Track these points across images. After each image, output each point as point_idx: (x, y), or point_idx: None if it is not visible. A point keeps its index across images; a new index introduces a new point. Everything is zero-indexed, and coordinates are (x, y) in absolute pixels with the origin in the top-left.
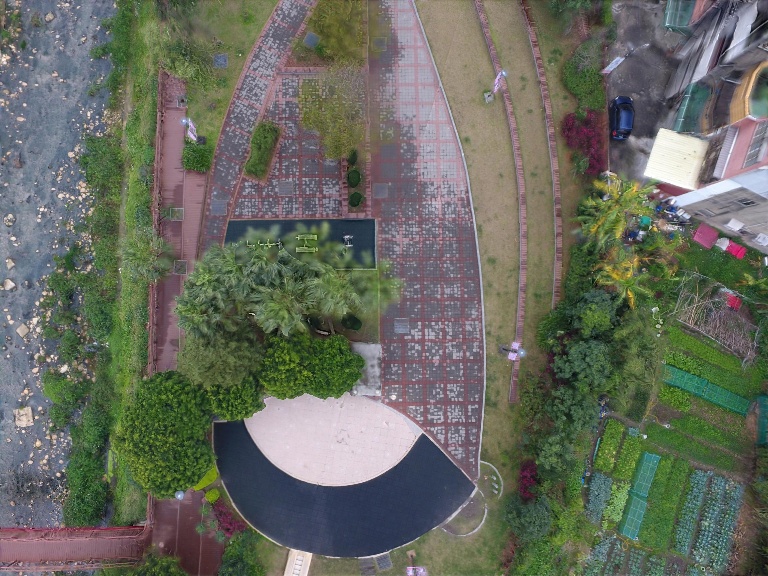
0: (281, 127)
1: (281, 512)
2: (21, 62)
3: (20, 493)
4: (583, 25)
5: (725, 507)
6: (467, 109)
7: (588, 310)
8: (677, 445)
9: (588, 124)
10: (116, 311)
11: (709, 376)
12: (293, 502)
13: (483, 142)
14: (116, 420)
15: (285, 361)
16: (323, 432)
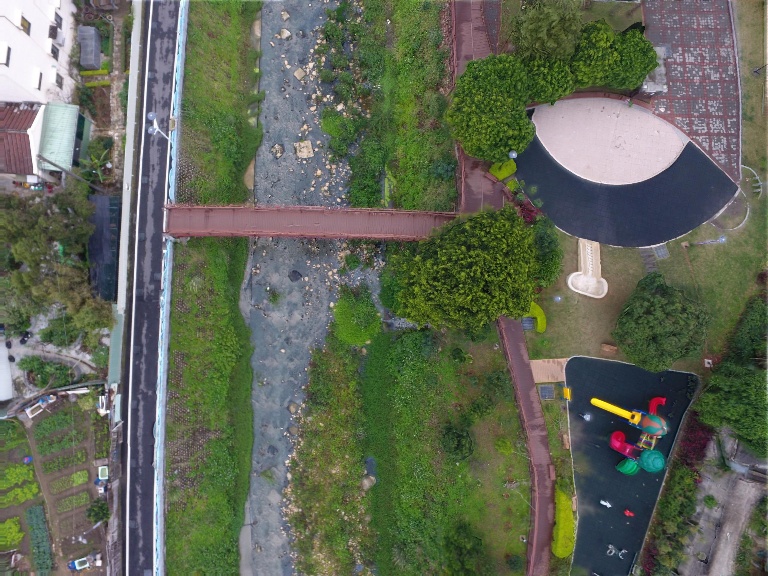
0: None
1: (570, 206)
2: None
3: None
4: None
5: None
6: None
7: None
8: None
9: None
10: (388, 54)
11: None
12: (580, 197)
13: None
14: (396, 146)
15: (603, 39)
16: (603, 138)
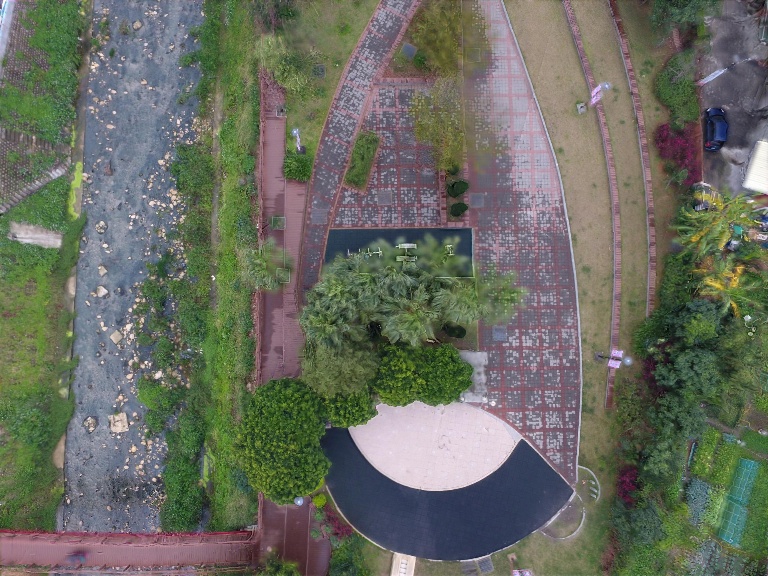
0: (379, 137)
1: (385, 516)
2: (110, 70)
3: (116, 498)
4: (674, 38)
5: None
6: (560, 120)
7: (693, 319)
8: None
9: (680, 135)
10: (210, 318)
11: None
12: (396, 507)
13: (576, 152)
14: (213, 426)
15: (402, 369)
16: (425, 438)
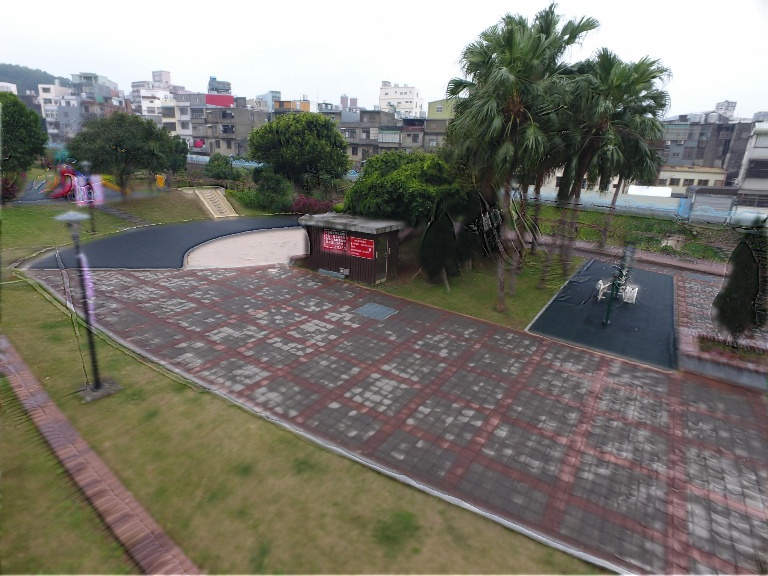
0: None
1: (276, 219)
2: None
3: None
4: None
5: None
6: None
7: None
8: None
9: None
10: None
11: None
12: (274, 222)
13: None
14: None
15: None
16: None
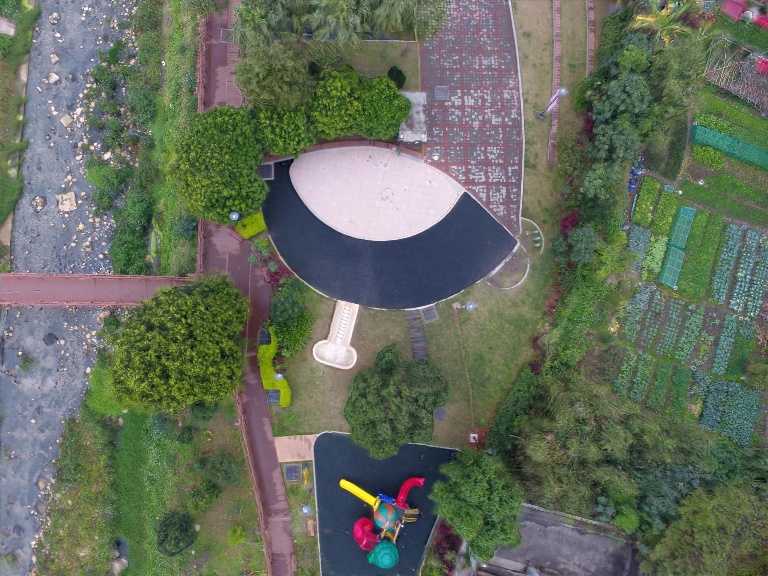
0: None
1: (328, 265)
2: None
3: None
4: None
5: (760, 260)
6: None
7: (625, 51)
8: (711, 201)
9: None
10: (159, 99)
11: (739, 136)
12: (339, 255)
13: None
14: (160, 198)
15: (337, 88)
16: (368, 190)
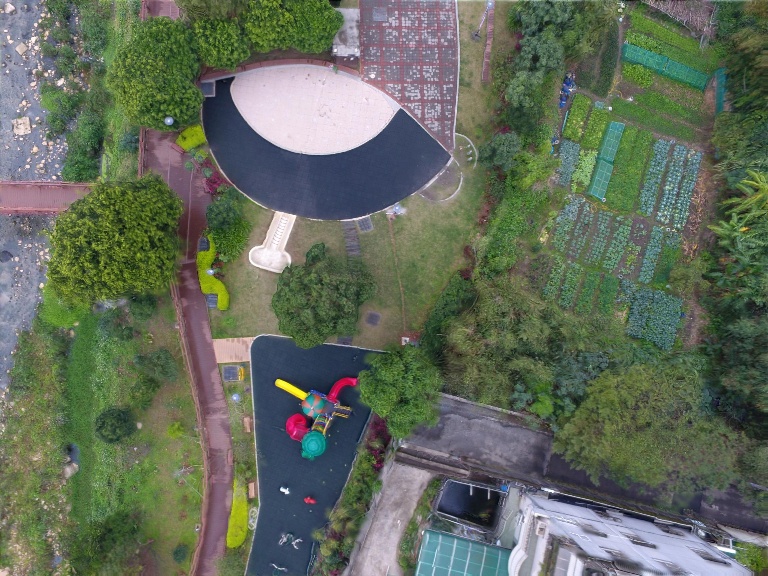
0: None
1: (267, 178)
2: None
3: None
4: None
5: (688, 173)
6: None
7: None
8: (641, 117)
9: None
10: (111, 26)
11: (669, 54)
12: (278, 169)
13: None
14: (110, 120)
15: None
16: (306, 106)
